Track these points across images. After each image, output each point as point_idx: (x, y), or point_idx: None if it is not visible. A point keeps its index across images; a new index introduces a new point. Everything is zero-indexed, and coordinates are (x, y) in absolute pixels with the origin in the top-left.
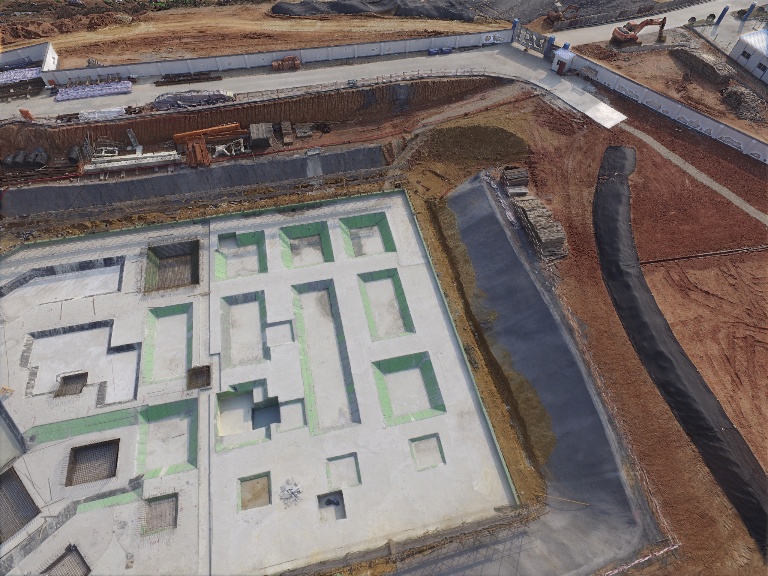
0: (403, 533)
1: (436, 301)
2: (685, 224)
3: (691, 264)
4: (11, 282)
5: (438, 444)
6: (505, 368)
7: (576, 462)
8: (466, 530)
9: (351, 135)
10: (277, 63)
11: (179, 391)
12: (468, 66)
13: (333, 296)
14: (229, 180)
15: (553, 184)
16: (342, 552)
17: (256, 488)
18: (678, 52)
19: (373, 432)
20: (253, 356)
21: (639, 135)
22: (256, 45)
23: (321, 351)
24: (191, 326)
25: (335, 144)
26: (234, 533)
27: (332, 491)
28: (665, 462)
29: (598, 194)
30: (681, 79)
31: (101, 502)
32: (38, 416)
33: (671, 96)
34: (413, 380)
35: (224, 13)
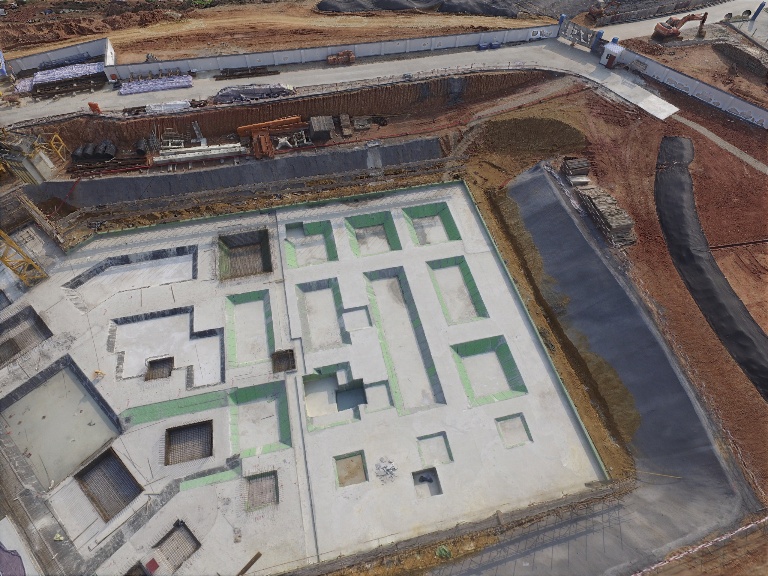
0: (499, 507)
1: (506, 287)
2: (749, 211)
3: (759, 249)
4: (88, 270)
5: (523, 423)
6: (582, 350)
7: (664, 438)
8: (570, 501)
9: (408, 128)
10: (332, 58)
11: (266, 374)
12: (518, 60)
13: (404, 283)
14: (292, 171)
15: (613, 173)
16: (442, 526)
17: (351, 466)
18: (722, 46)
19: (459, 412)
20: (332, 341)
21: (693, 126)
22: (308, 41)
23: (398, 335)
24: (270, 312)
25: (393, 136)
26: (335, 508)
27: (426, 468)
28: (755, 436)
29: (659, 183)
30: (727, 72)
31: (202, 480)
32: (131, 398)
33: None
34: (490, 363)
35: (271, 10)
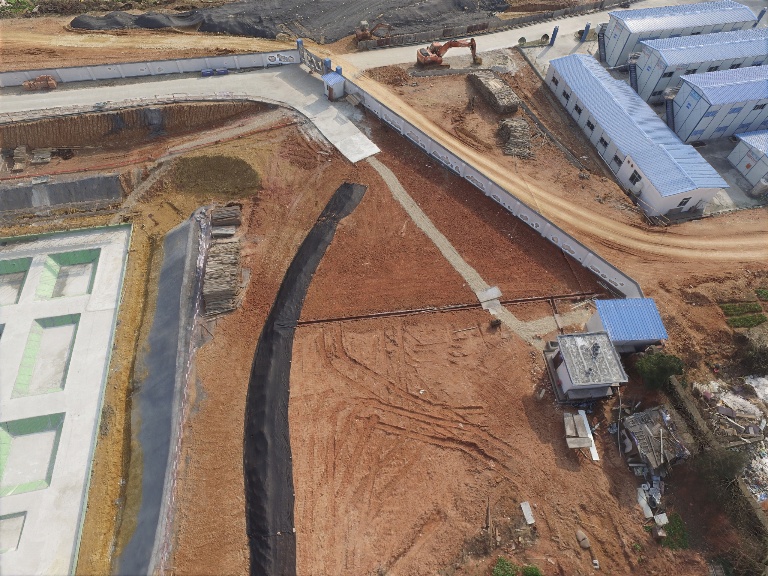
0: None
1: (104, 353)
2: (373, 278)
3: (356, 326)
4: None
5: (22, 524)
6: (133, 437)
7: (135, 559)
8: None
9: (92, 162)
10: (28, 83)
11: None
12: (236, 89)
13: None
14: None
15: (268, 225)
16: None
17: None
18: (473, 77)
19: None
20: None
21: (382, 171)
22: (27, 62)
23: None
24: None
25: (69, 172)
26: None
27: None
28: (204, 570)
29: (307, 238)
30: (464, 108)
31: None
32: None
33: (443, 127)
34: (42, 444)
35: (21, 26)
